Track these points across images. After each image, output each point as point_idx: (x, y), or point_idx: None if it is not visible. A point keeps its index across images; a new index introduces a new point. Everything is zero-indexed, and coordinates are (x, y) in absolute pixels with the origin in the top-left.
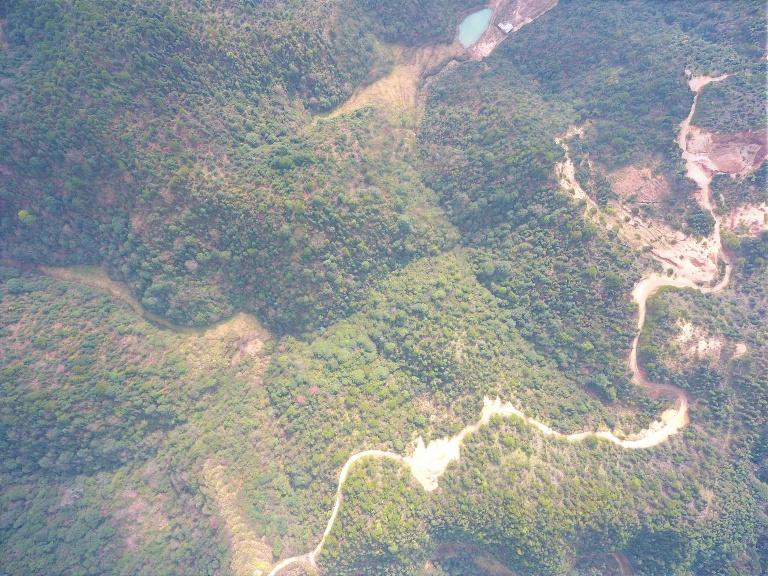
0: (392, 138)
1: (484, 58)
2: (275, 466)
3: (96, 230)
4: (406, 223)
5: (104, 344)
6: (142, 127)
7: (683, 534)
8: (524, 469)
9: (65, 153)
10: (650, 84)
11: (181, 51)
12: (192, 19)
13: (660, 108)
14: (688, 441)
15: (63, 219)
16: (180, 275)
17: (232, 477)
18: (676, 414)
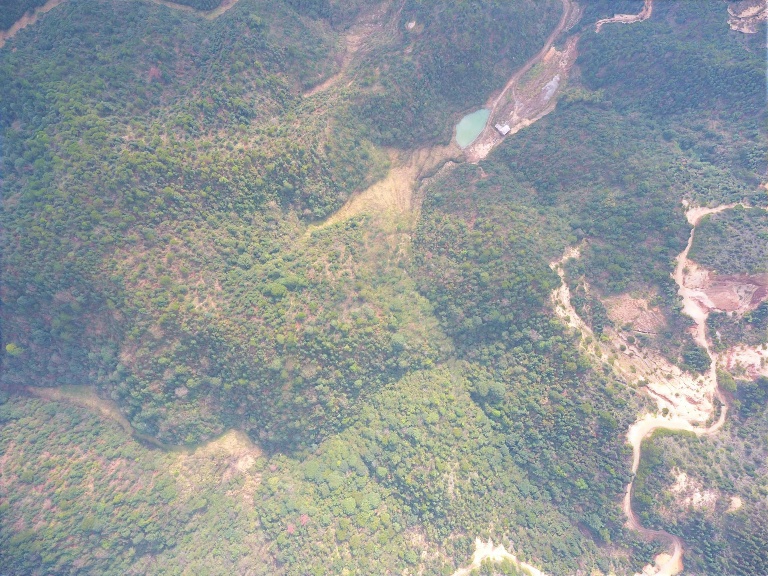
0: (387, 247)
1: (481, 162)
2: None
3: (85, 357)
4: (400, 344)
5: (92, 472)
6: (132, 263)
7: None
8: None
9: (53, 293)
10: (647, 211)
11: (173, 181)
12: (184, 147)
13: (657, 237)
14: None
15: (51, 348)
16: (170, 400)
17: None
18: (670, 559)
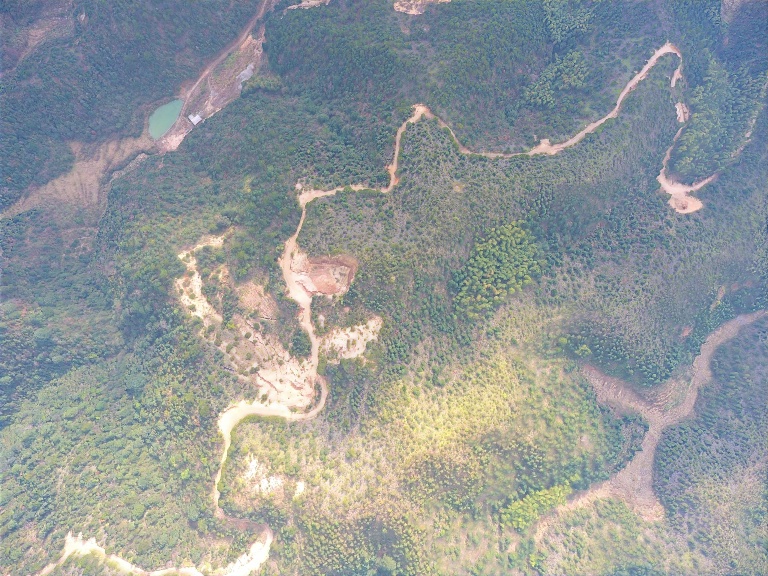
0: (58, 241)
1: (166, 153)
2: None
3: None
4: (40, 338)
5: None
6: None
7: None
8: None
9: None
10: None
11: None
12: None
13: (278, 221)
14: None
15: None
16: None
17: None
18: (262, 547)
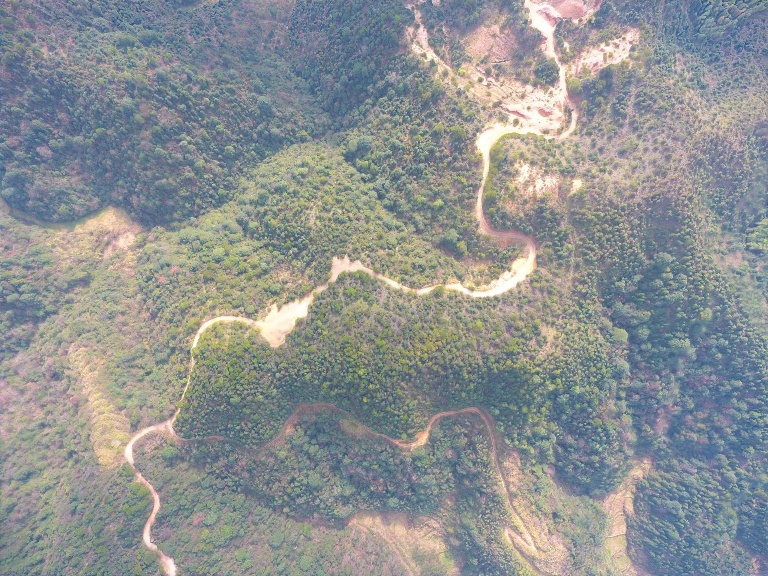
0: (258, 28)
1: None
2: (140, 347)
3: None
4: (265, 103)
5: None
6: None
7: (524, 370)
8: (364, 316)
9: None
10: None
11: None
12: None
13: None
14: (533, 284)
15: None
16: (35, 164)
17: (94, 357)
18: (525, 262)
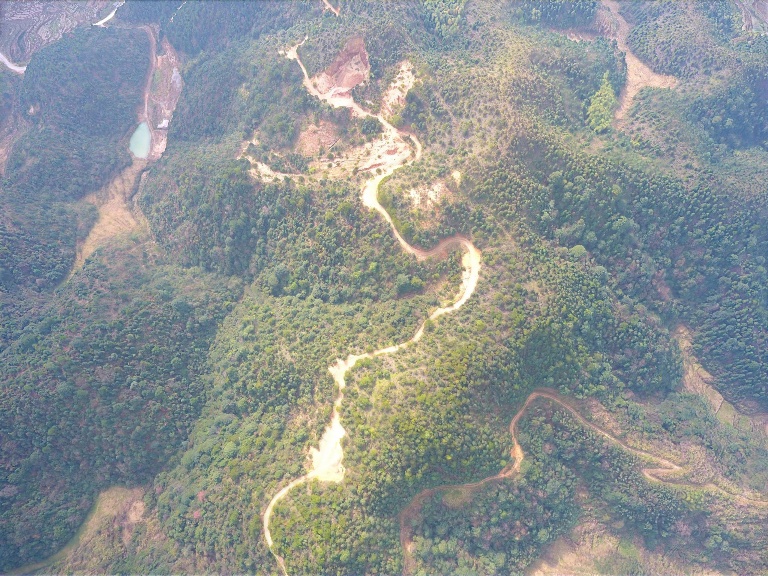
0: (131, 257)
1: (162, 154)
2: None
3: None
4: (180, 303)
5: None
6: None
7: (541, 327)
8: (391, 390)
9: None
10: (267, 77)
11: None
12: None
13: (286, 85)
14: (489, 264)
15: None
16: (5, 510)
17: None
18: (470, 255)
